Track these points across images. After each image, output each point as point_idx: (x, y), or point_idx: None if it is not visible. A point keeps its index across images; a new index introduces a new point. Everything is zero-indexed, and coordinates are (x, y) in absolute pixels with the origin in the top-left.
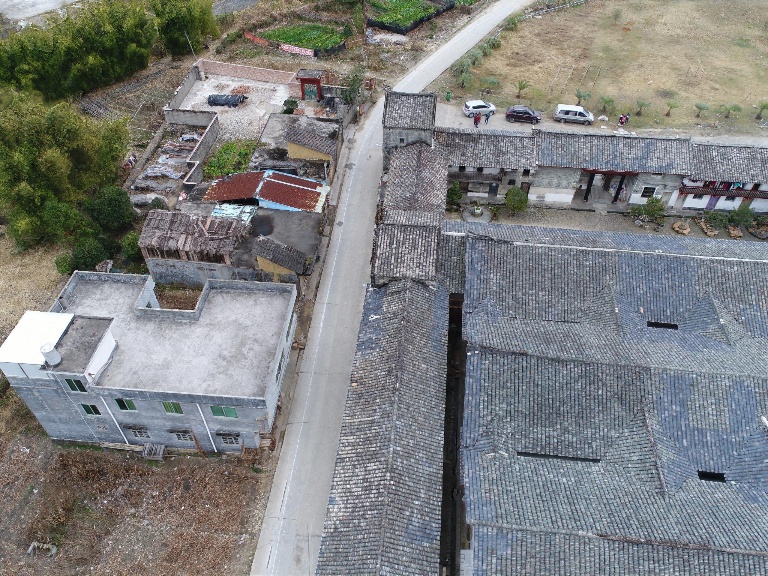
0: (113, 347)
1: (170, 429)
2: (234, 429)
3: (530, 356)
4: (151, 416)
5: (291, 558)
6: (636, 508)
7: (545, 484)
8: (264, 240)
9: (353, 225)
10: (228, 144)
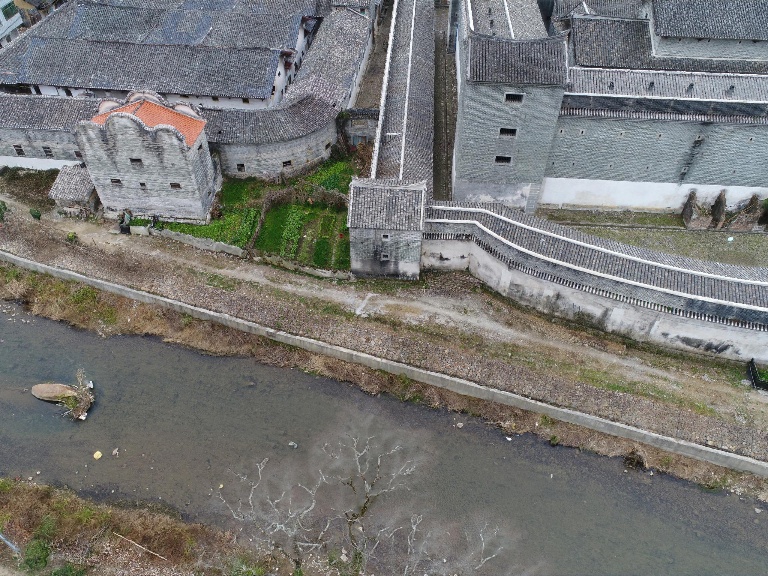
0: None
1: None
2: None
3: (109, 6)
4: None
5: None
6: None
7: None
8: None
9: None
10: None
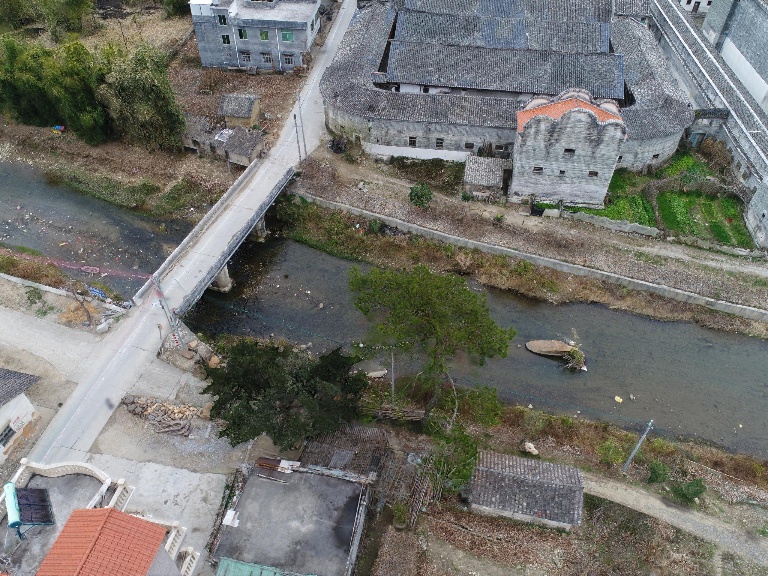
0: (236, 12)
1: (261, 52)
2: (291, 50)
3: (427, 13)
4: (253, 42)
5: (317, 93)
6: None
7: None
8: None
9: (351, 9)
10: None
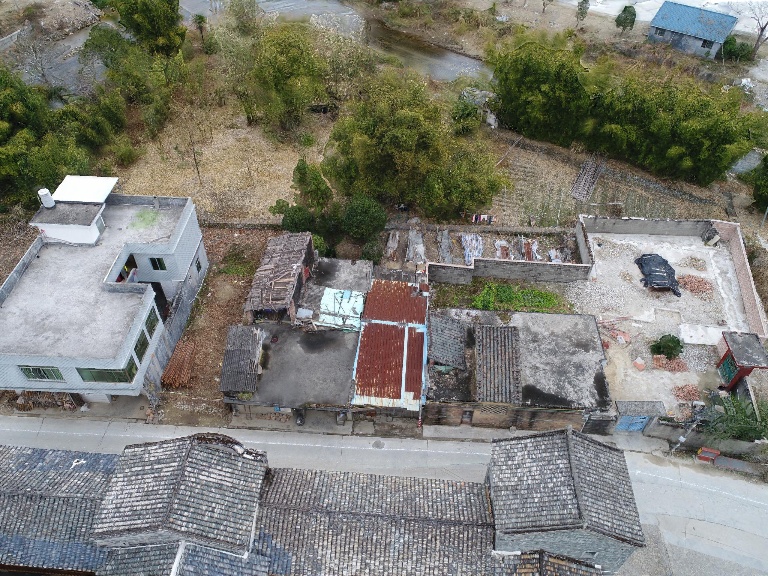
0: (88, 242)
1: None
2: None
3: None
4: None
5: None
6: None
7: None
8: (255, 335)
9: (375, 463)
10: (556, 297)
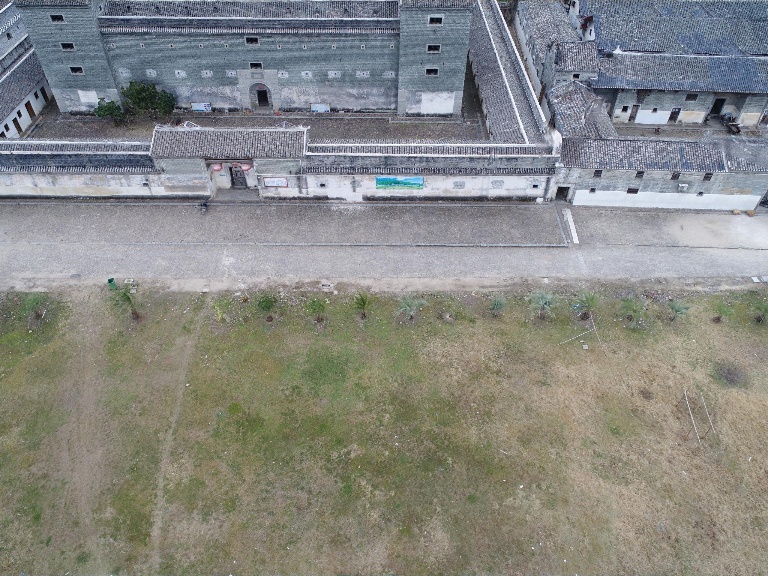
0: None
1: None
2: None
3: None
4: None
5: None
6: (715, 1)
7: (748, 7)
8: None
9: None
10: None
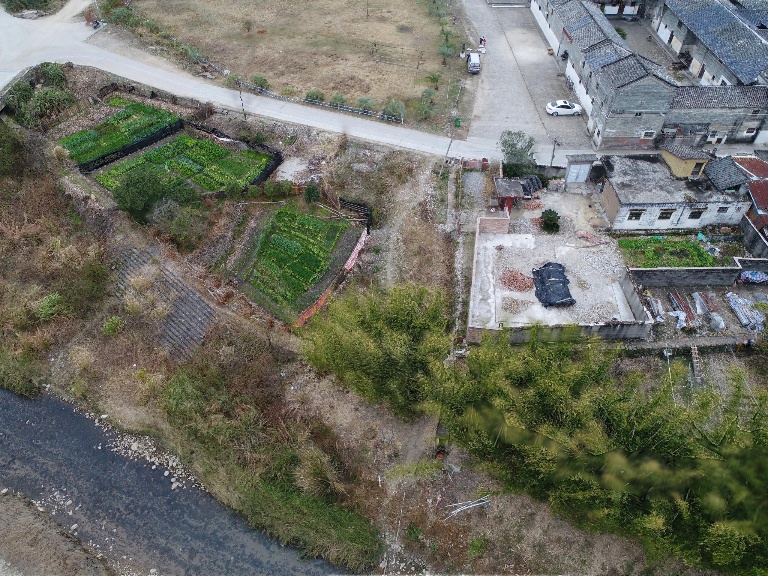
0: None
1: None
2: None
3: None
4: None
5: None
6: None
7: None
8: None
9: None
10: None
